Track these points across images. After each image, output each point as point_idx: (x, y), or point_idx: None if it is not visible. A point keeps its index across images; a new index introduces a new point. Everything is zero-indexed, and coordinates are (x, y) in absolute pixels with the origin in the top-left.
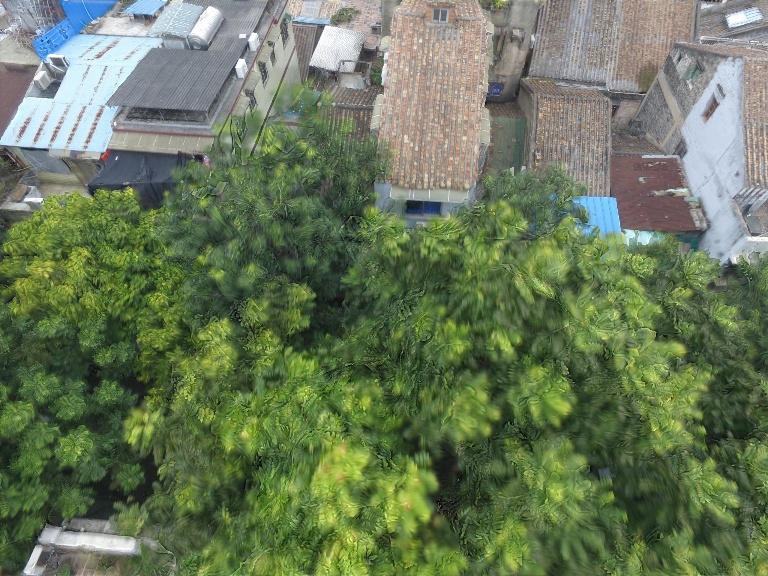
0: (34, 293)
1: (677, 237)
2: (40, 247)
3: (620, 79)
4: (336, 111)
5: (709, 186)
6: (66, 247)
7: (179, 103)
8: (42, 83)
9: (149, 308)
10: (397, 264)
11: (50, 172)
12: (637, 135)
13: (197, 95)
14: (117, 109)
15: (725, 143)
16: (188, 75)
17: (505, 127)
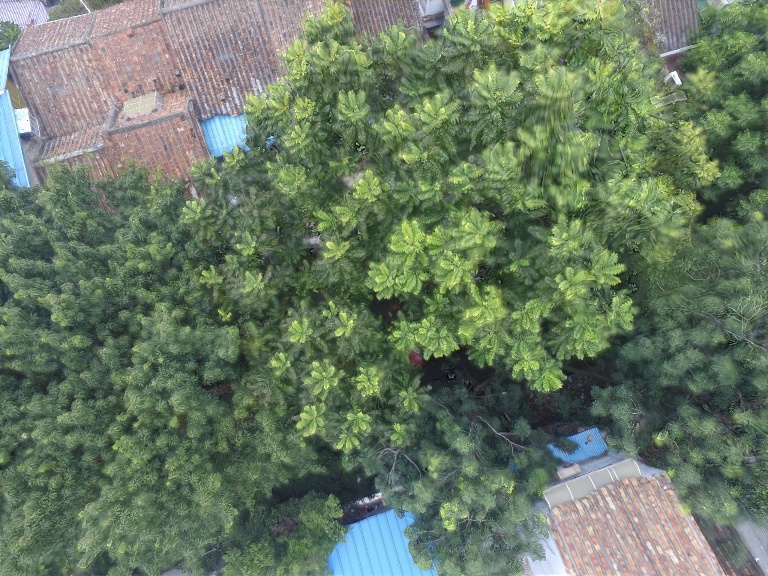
0: None
1: None
2: None
3: None
4: None
5: None
6: None
7: None
8: None
9: None
10: None
11: None
12: None
13: None
14: None
15: None
16: None
17: None
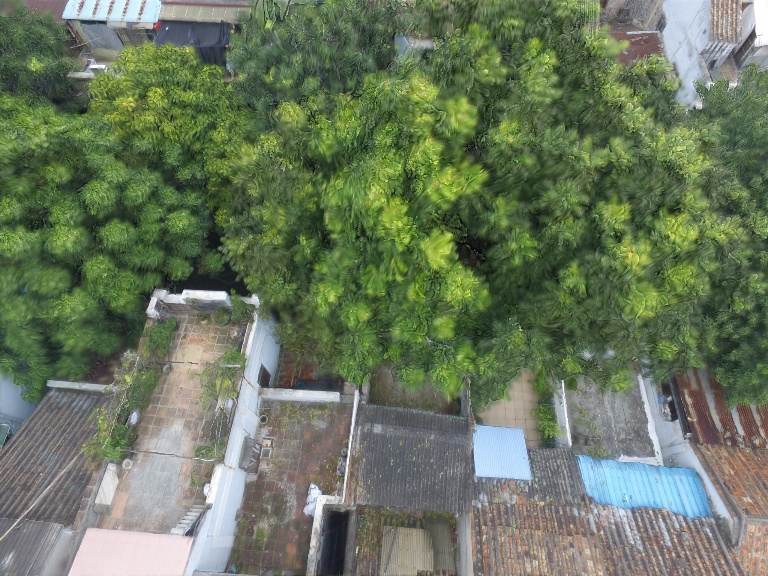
0: (120, 126)
1: None
2: (121, 88)
3: None
4: None
5: (682, 50)
6: (142, 90)
7: None
8: None
9: (213, 141)
10: (432, 18)
11: (104, 48)
12: (625, 22)
13: None
14: None
15: (697, 7)
16: None
17: None
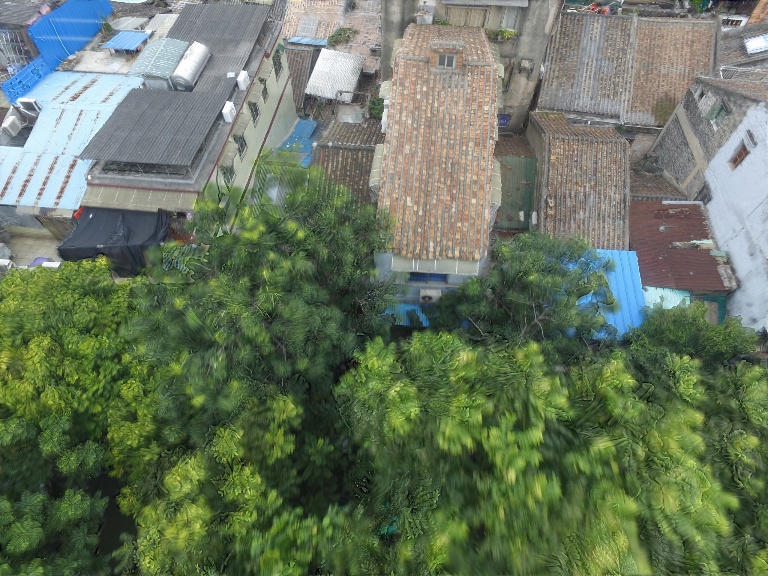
0: None
1: (703, 296)
2: None
3: (635, 111)
4: (332, 152)
5: (738, 241)
6: (28, 330)
7: (159, 156)
8: (11, 129)
9: (121, 398)
10: (403, 451)
11: (20, 226)
12: (653, 172)
13: (179, 146)
14: (92, 160)
15: (757, 197)
16: (170, 122)
17: (514, 167)
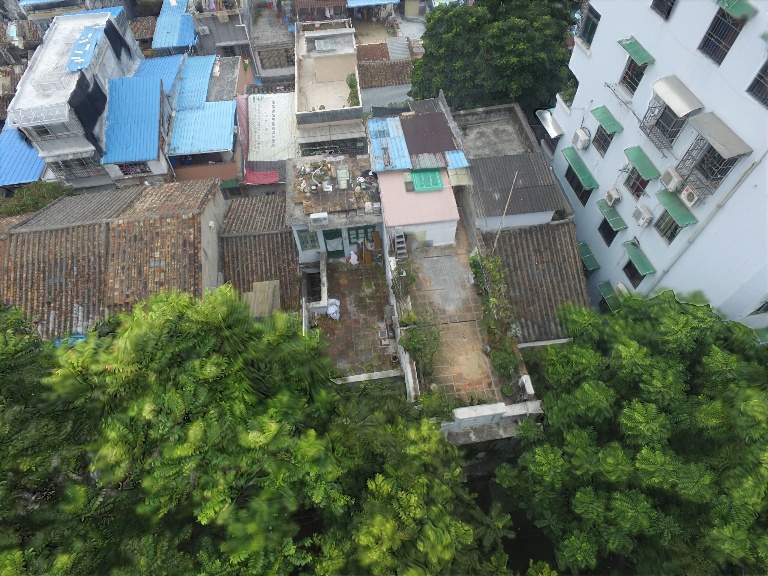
0: None
1: None
2: None
3: None
4: None
5: None
6: None
7: None
8: None
9: None
10: None
11: None
12: None
13: None
14: None
15: None
16: None
17: None
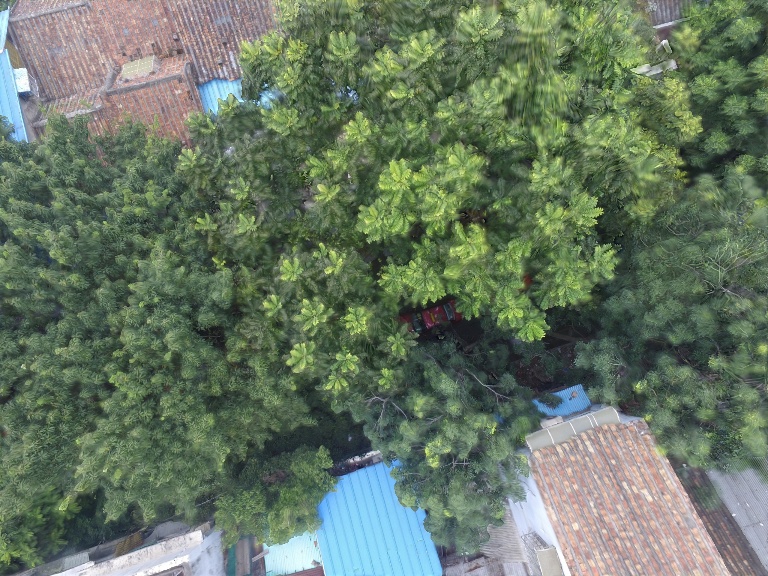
0: None
1: None
2: None
3: None
4: None
5: None
6: None
7: None
8: None
9: (748, 212)
10: None
11: None
12: None
13: None
14: None
15: None
16: None
17: None
